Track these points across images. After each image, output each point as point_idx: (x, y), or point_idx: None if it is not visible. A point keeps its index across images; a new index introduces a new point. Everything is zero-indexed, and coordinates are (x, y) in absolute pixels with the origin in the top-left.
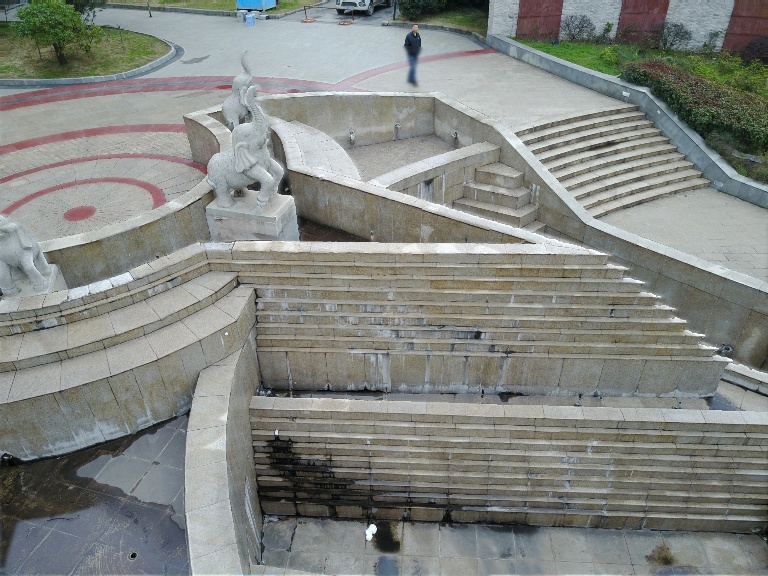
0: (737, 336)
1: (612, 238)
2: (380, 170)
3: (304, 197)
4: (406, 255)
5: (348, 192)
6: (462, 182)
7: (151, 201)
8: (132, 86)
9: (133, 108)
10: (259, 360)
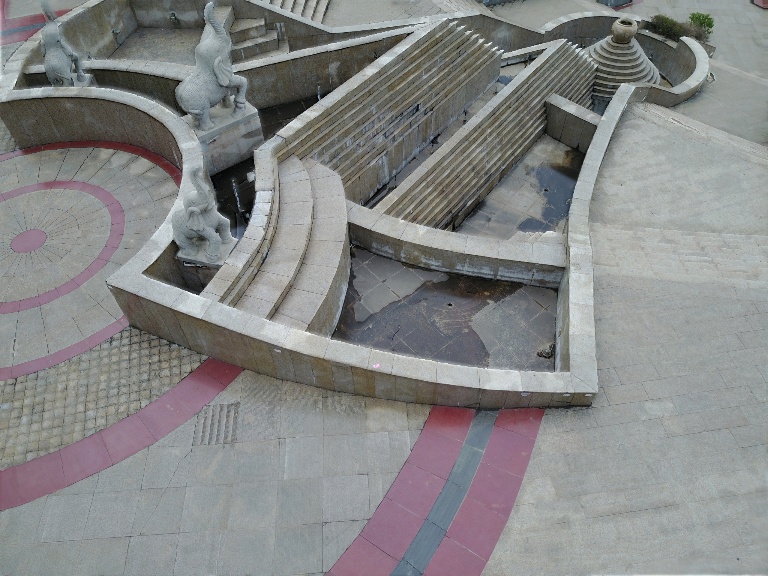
0: None
1: (356, 34)
2: None
3: None
4: (372, 76)
5: (258, 72)
6: None
7: (71, 191)
8: None
9: None
10: None
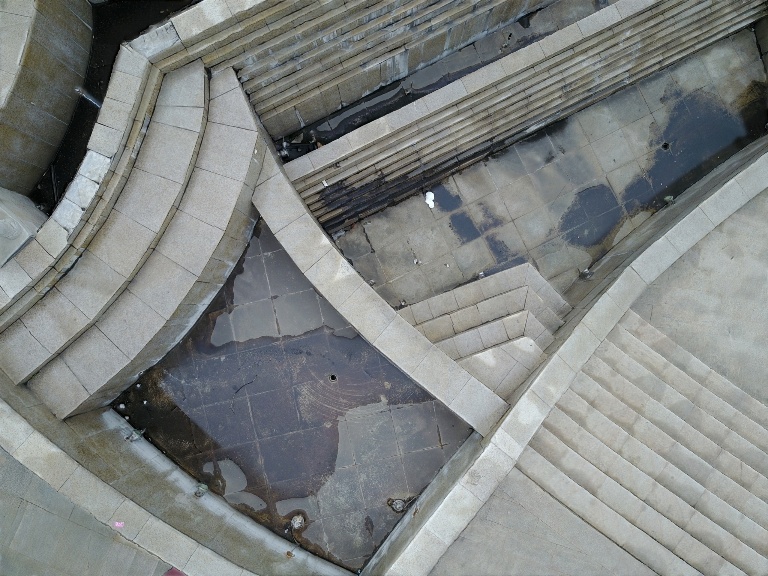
0: None
1: None
2: None
3: None
4: None
5: None
6: None
7: None
8: None
9: None
10: (265, 126)
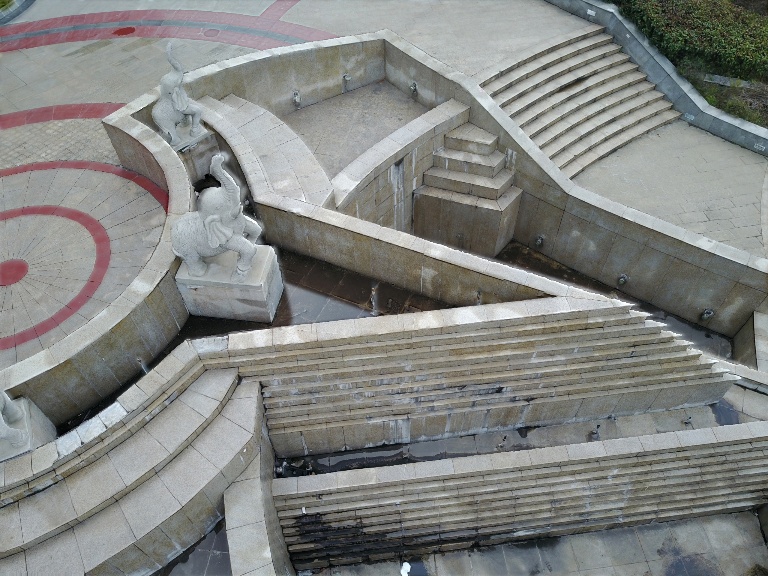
0: (720, 303)
1: (597, 210)
2: (337, 142)
3: (277, 228)
4: (423, 330)
5: (332, 229)
6: (431, 152)
7: (92, 242)
8: (5, 39)
9: (18, 79)
10: (271, 441)
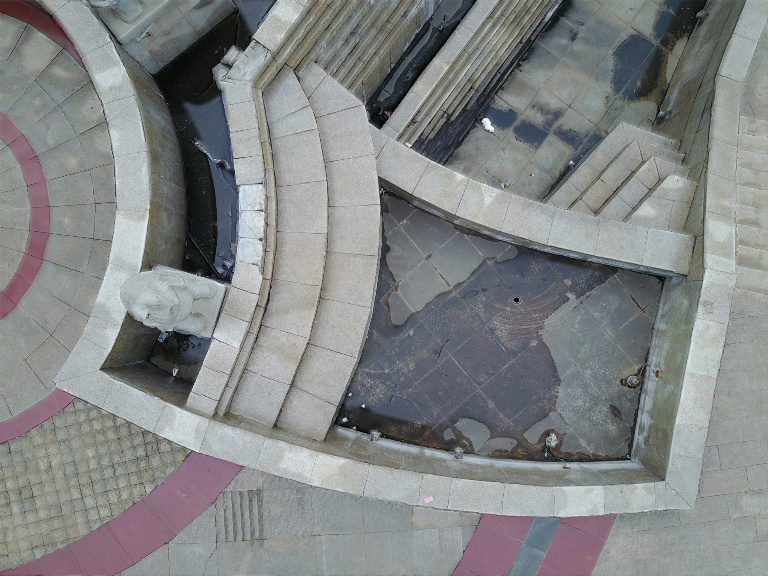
0: None
1: None
2: None
3: None
4: None
5: None
6: None
7: None
8: None
9: None
10: None
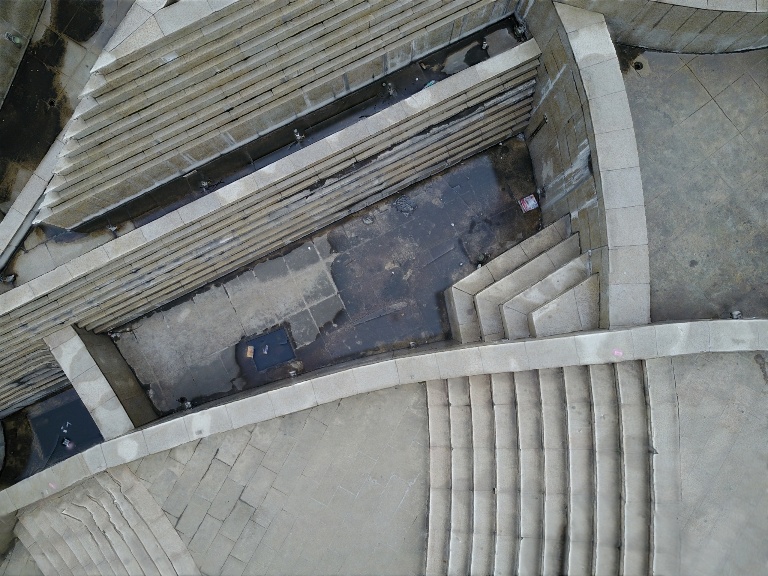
0: None
1: None
2: (711, 142)
3: None
4: None
5: None
6: None
7: None
8: None
9: None
10: None
